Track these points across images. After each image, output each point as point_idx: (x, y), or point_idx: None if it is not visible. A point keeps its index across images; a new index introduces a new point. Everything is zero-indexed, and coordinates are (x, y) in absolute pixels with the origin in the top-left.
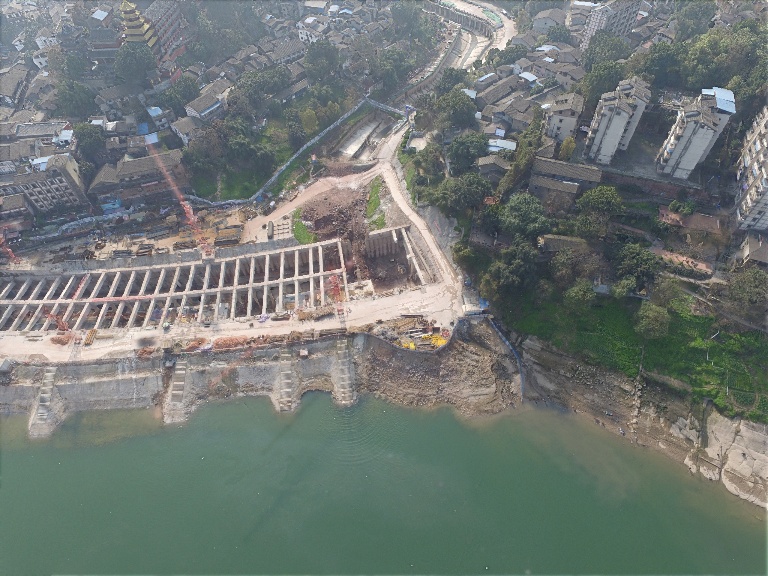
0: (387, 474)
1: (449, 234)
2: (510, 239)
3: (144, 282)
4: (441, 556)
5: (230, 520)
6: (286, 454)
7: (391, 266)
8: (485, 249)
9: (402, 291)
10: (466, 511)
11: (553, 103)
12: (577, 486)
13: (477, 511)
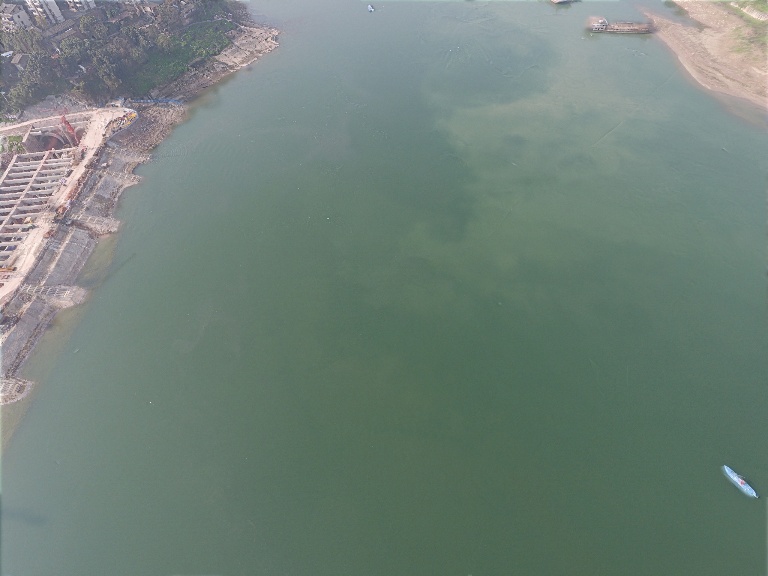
0: (197, 143)
1: (58, 103)
2: (87, 63)
3: None
4: (239, 128)
5: (193, 194)
6: (167, 180)
7: (56, 156)
8: (86, 77)
9: (87, 128)
10: (225, 123)
11: (0, 15)
12: (228, 96)
13: (226, 119)
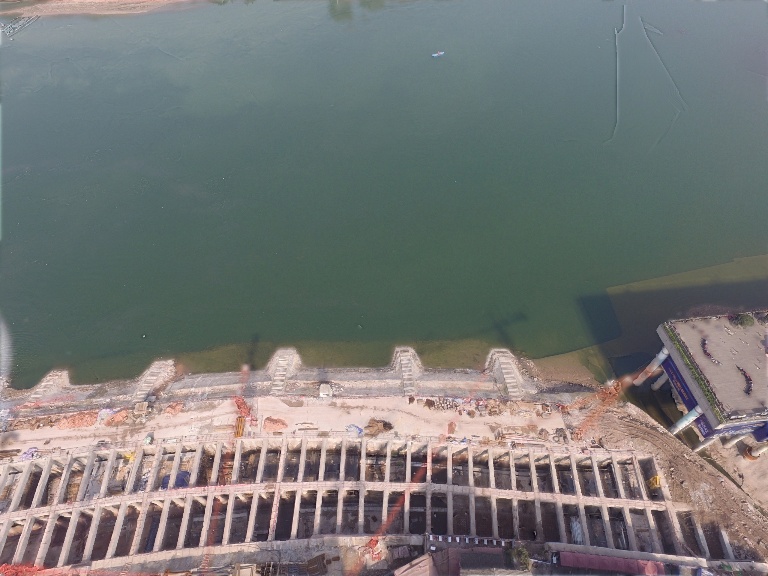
0: None
1: None
2: None
3: (184, 522)
4: None
5: (126, 298)
6: (73, 340)
7: None
8: None
9: None
10: None
11: None
12: None
13: None
